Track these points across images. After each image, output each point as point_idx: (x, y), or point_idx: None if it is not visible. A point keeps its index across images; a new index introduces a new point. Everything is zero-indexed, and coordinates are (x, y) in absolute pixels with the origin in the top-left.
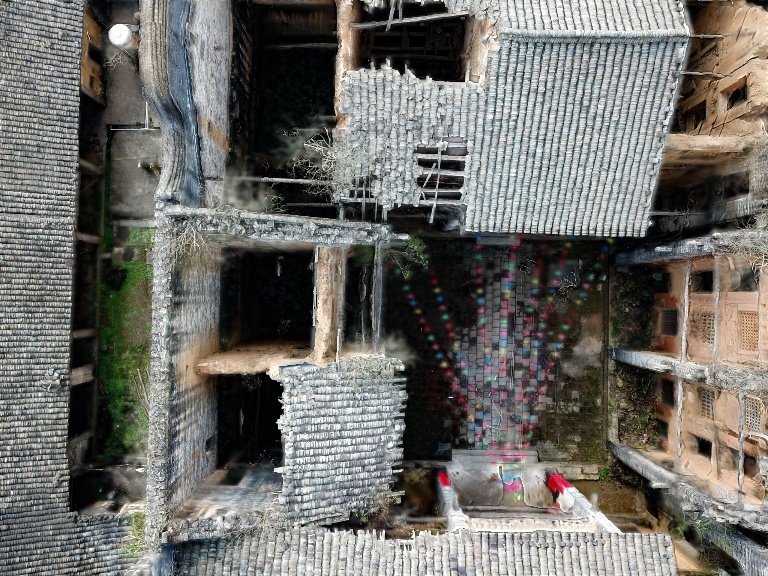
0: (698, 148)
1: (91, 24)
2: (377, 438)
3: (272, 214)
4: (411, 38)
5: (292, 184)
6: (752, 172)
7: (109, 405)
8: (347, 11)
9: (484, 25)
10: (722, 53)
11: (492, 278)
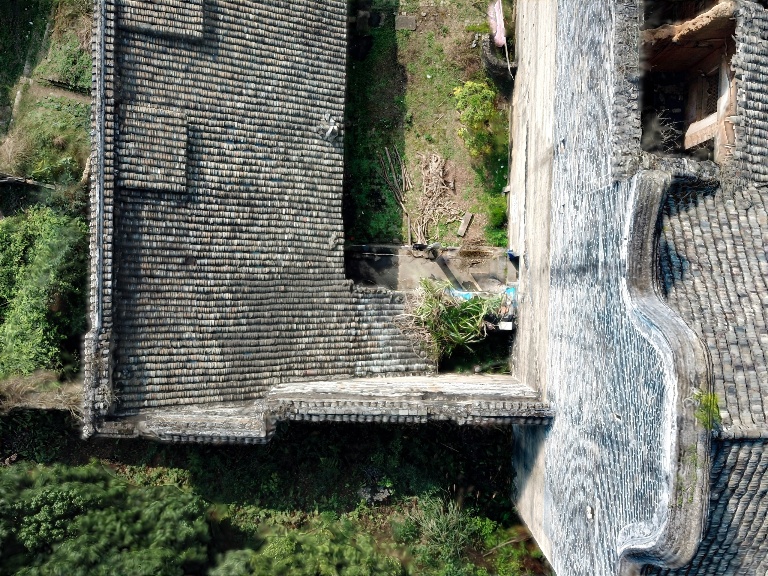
0: None
1: None
2: None
3: None
4: None
5: None
6: None
7: (352, 190)
8: None
9: None
10: None
11: None
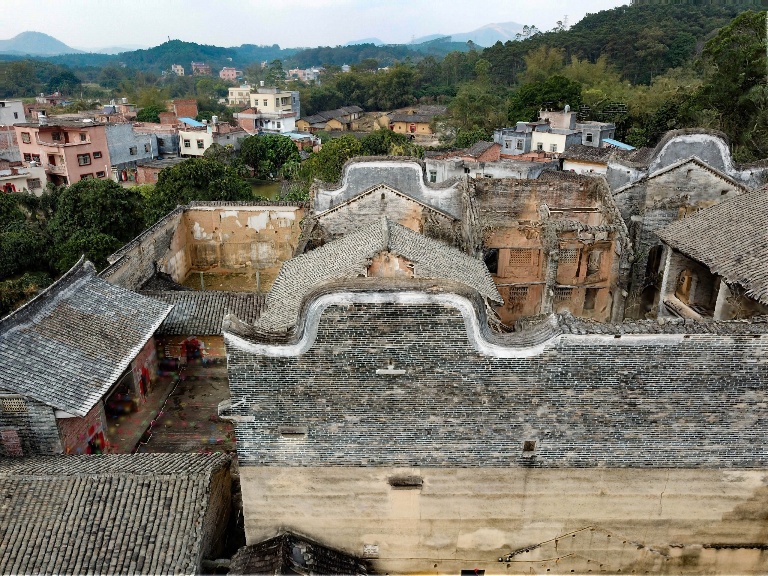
0: None
1: None
2: None
3: None
4: None
5: None
6: None
7: None
8: None
9: (371, 271)
10: None
11: None
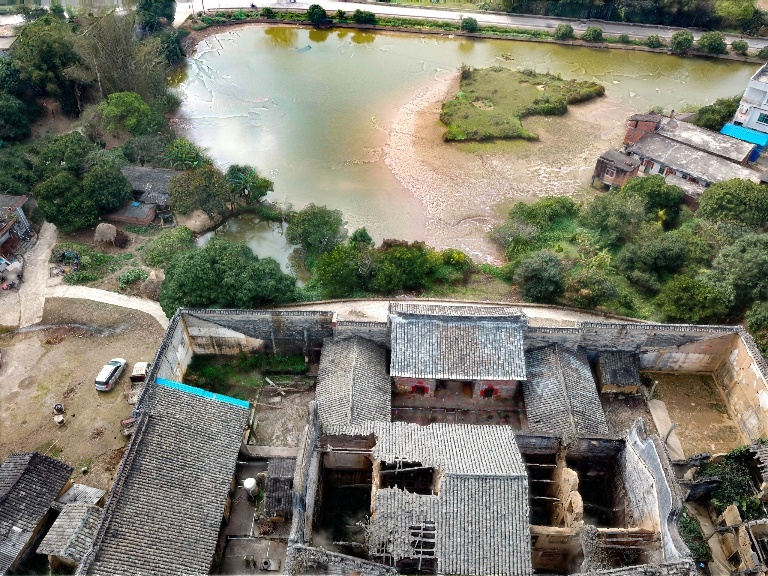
0: (552, 533)
1: (233, 478)
2: None
3: None
4: (407, 482)
5: (348, 545)
6: (583, 545)
7: None
8: (378, 465)
9: (439, 472)
10: (563, 492)
11: None
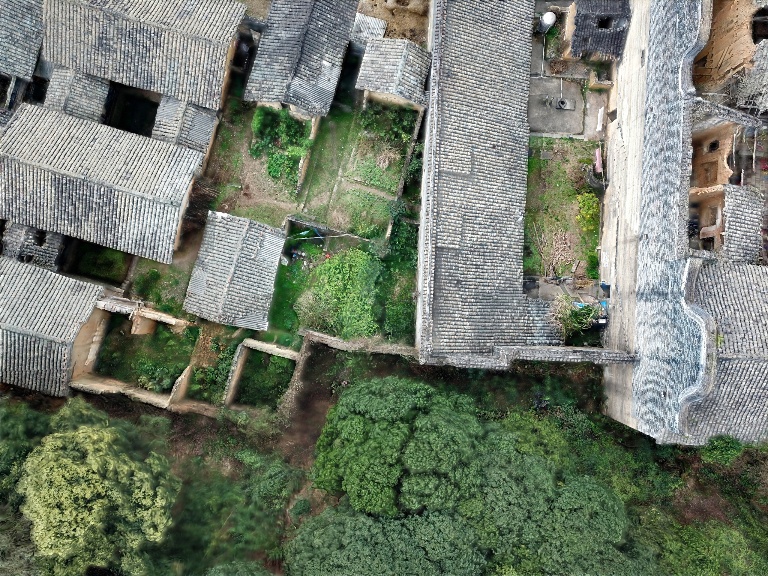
0: None
1: None
2: (755, 227)
3: (727, 107)
4: None
5: None
6: None
7: None
8: (758, 10)
9: None
10: None
11: (746, 175)
